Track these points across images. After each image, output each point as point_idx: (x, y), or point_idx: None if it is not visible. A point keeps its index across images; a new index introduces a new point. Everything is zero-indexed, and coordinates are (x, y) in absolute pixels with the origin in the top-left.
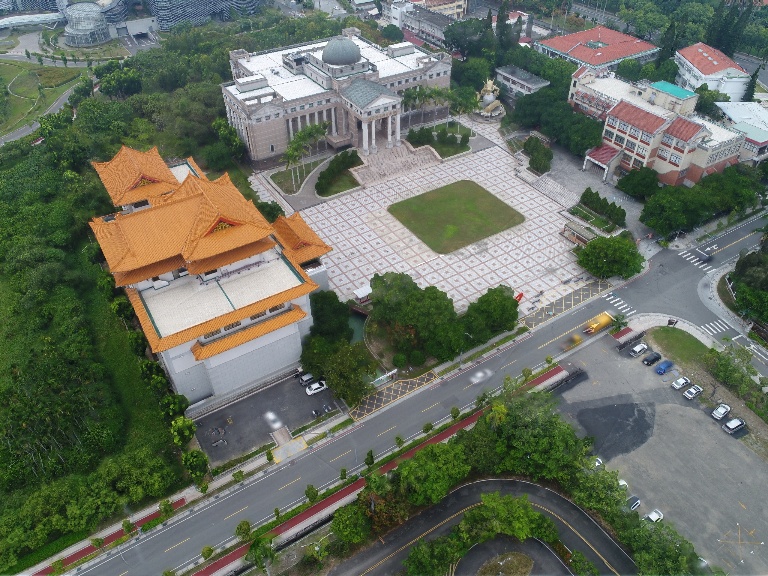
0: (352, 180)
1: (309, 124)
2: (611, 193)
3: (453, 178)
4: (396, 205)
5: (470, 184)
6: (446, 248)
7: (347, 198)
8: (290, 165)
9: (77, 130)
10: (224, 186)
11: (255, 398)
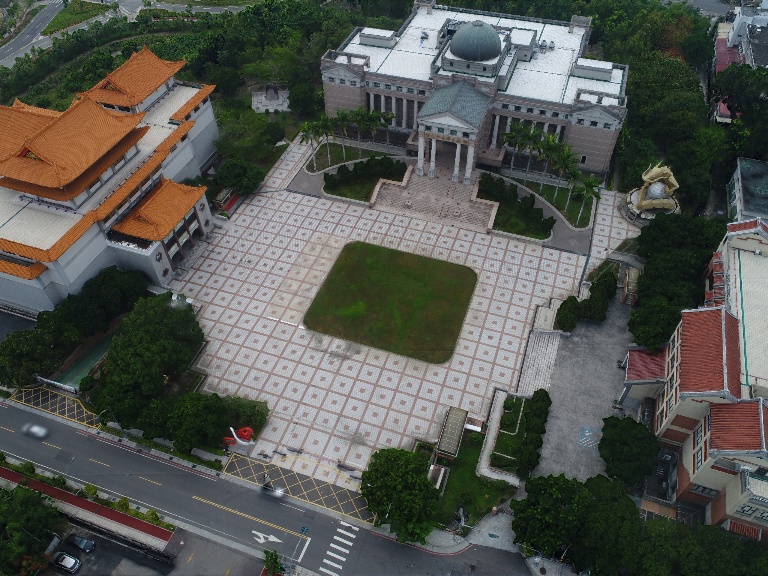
0: (369, 192)
1: (394, 109)
2: (597, 424)
3: (464, 258)
4: (361, 245)
5: (467, 278)
6: (318, 323)
7: (340, 207)
8: (358, 143)
9: (238, 21)
10: (119, 123)
11: (8, 317)
